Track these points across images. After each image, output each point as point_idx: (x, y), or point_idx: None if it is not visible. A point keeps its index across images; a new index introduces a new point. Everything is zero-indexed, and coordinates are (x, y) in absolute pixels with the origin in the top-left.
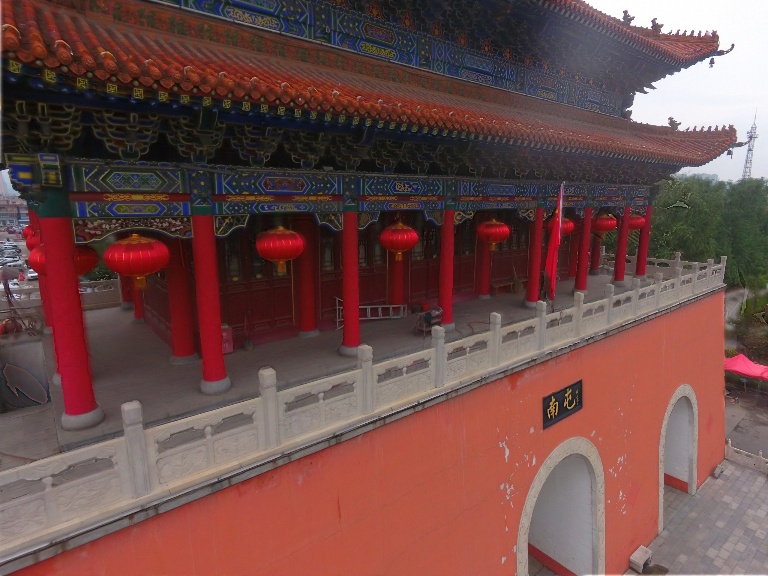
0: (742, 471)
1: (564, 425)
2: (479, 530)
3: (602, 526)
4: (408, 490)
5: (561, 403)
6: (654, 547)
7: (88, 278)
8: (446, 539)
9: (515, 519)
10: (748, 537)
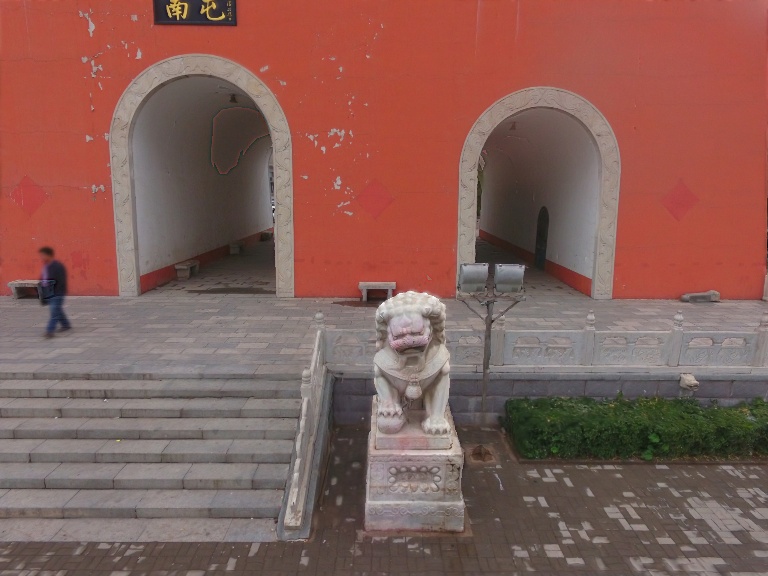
0: (764, 307)
1: (196, 33)
2: (52, 89)
3: (287, 202)
4: None
5: (195, 8)
6: None
7: None
8: (6, 75)
9: (108, 106)
10: None
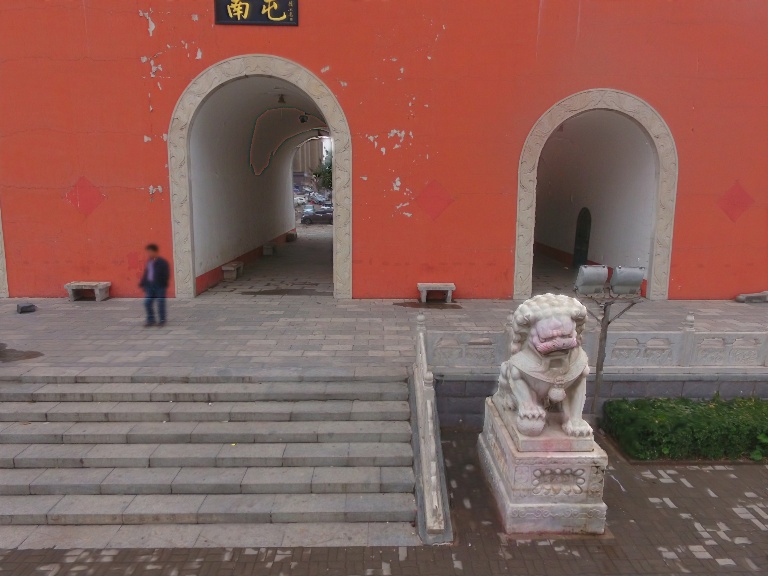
0: None
1: (257, 33)
2: (110, 89)
3: (346, 203)
4: (19, 8)
5: (256, 8)
6: (484, 301)
7: (324, 185)
8: (64, 74)
9: (167, 106)
10: (657, 324)
